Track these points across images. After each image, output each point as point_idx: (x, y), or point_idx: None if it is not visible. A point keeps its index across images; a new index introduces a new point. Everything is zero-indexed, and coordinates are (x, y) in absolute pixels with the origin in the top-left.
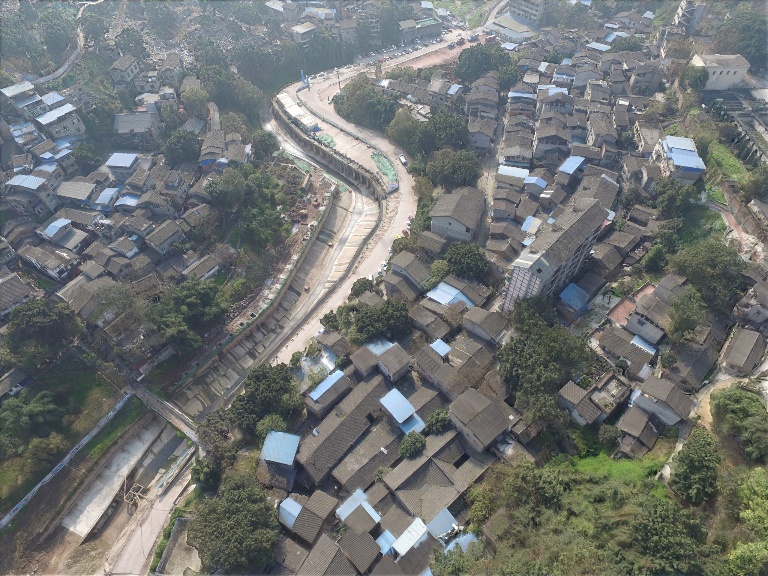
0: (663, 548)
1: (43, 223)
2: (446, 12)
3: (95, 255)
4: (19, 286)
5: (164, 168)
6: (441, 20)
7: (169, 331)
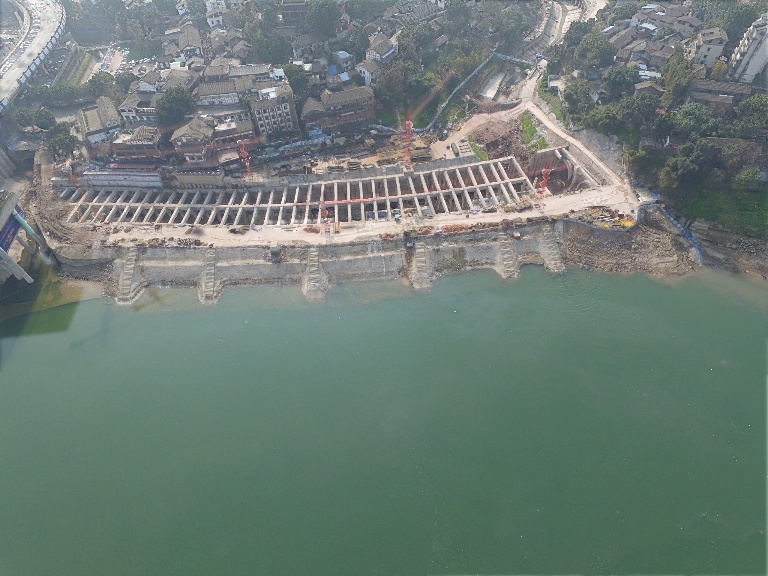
0: None
1: None
2: None
3: None
4: (433, 5)
5: None
6: None
7: None
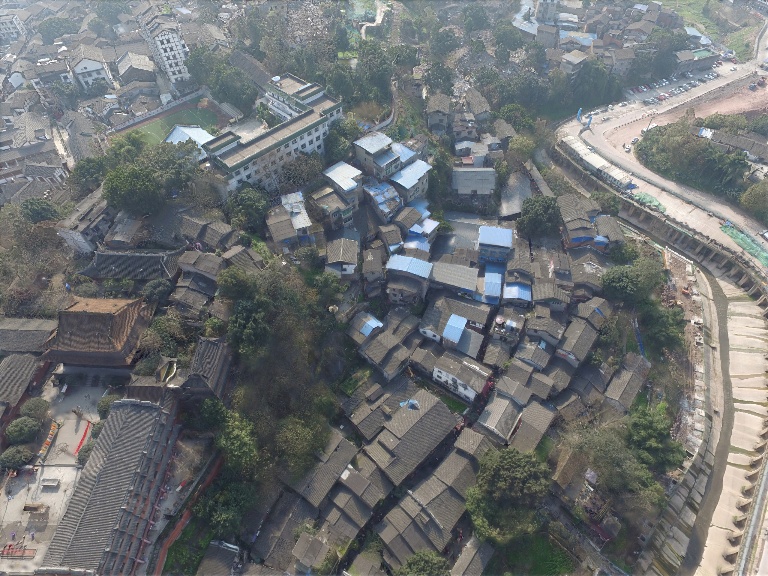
0: None
1: (426, 318)
2: (708, 40)
3: (504, 367)
4: (445, 414)
5: (522, 242)
6: (719, 52)
7: (653, 494)
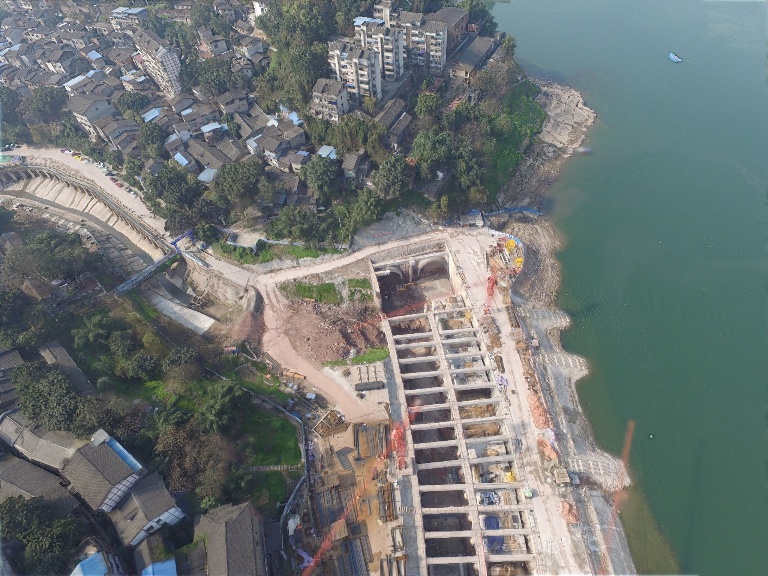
0: (295, 26)
1: None
2: None
3: None
4: None
5: None
6: None
7: (78, 250)
